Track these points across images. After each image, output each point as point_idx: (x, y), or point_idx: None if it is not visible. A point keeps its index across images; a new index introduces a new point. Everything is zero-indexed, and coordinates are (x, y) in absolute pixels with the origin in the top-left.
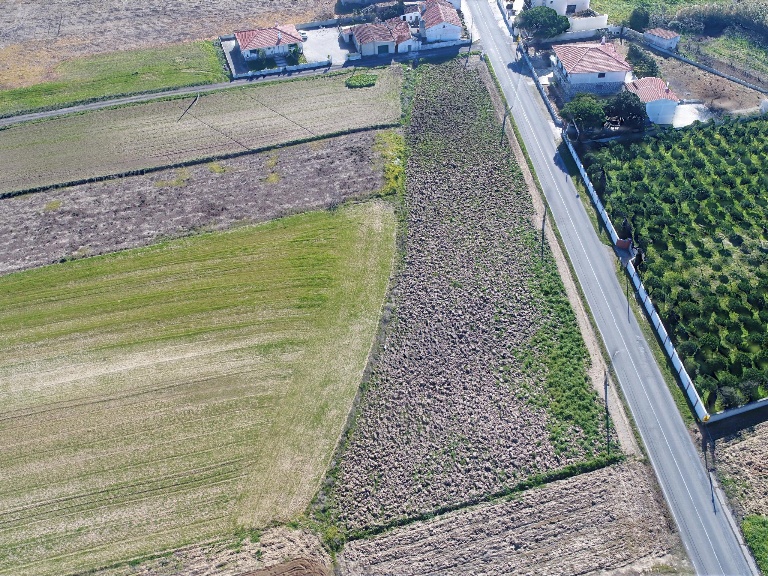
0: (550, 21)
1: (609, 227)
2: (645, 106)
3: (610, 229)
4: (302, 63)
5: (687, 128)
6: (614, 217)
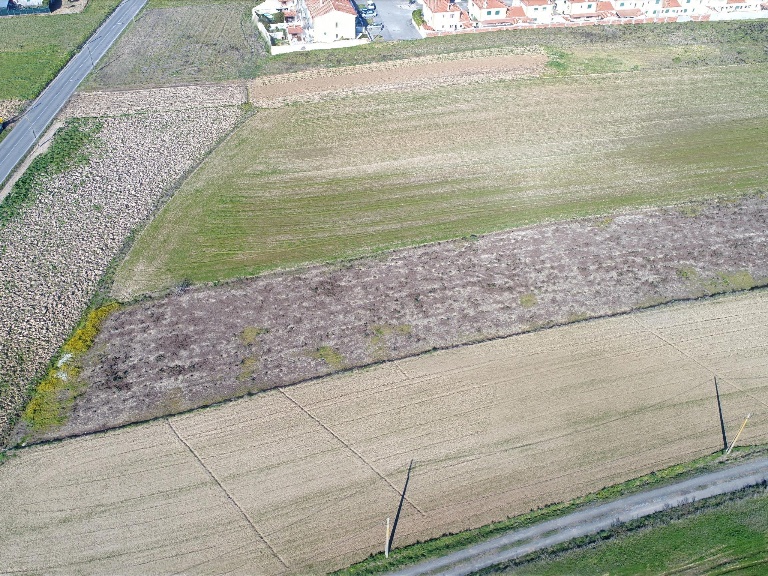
0: None
1: None
2: None
3: None
4: None
5: None
6: None
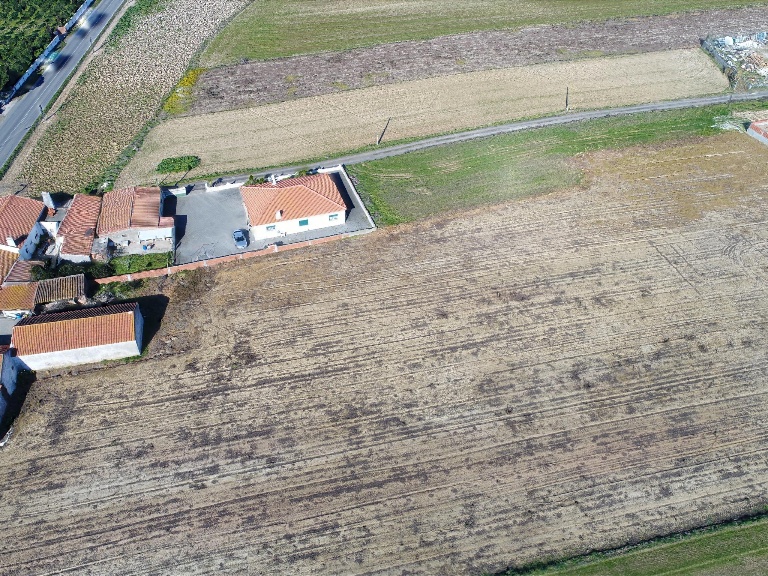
0: None
1: None
2: None
3: None
4: None
5: None
6: None
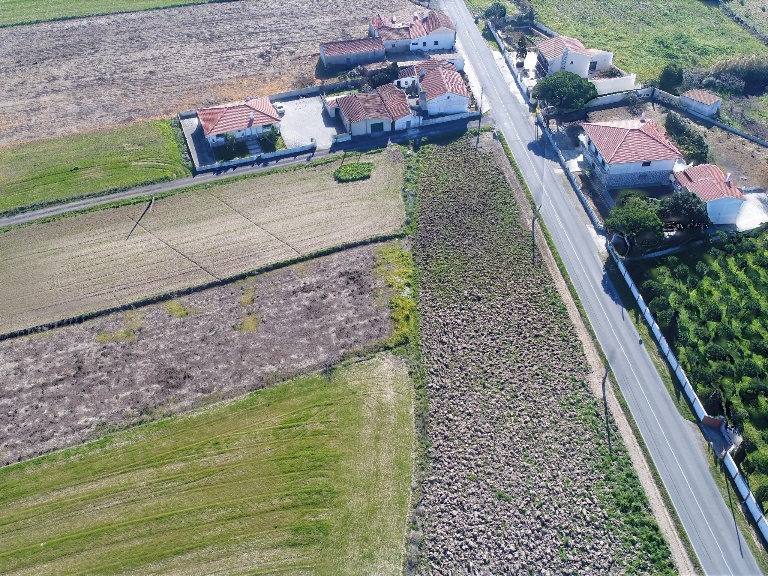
0: (576, 91)
1: (690, 394)
2: (706, 207)
3: (692, 397)
4: (280, 149)
5: (757, 232)
6: (696, 381)
